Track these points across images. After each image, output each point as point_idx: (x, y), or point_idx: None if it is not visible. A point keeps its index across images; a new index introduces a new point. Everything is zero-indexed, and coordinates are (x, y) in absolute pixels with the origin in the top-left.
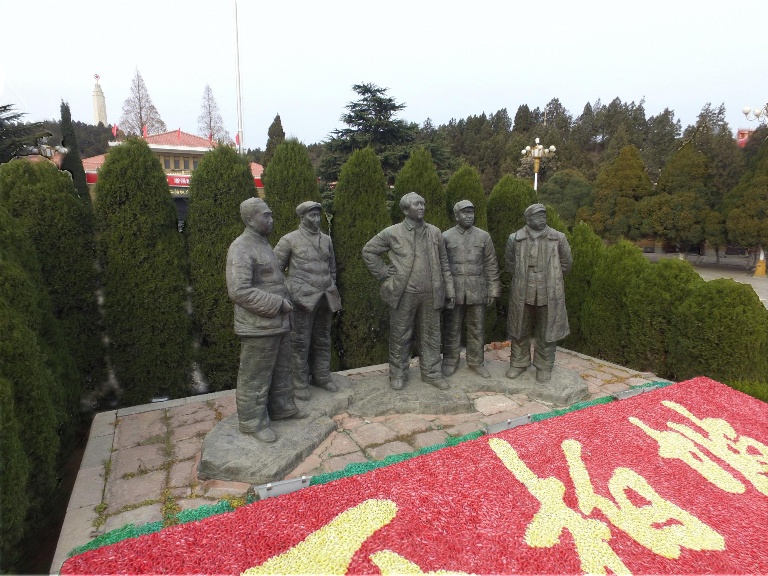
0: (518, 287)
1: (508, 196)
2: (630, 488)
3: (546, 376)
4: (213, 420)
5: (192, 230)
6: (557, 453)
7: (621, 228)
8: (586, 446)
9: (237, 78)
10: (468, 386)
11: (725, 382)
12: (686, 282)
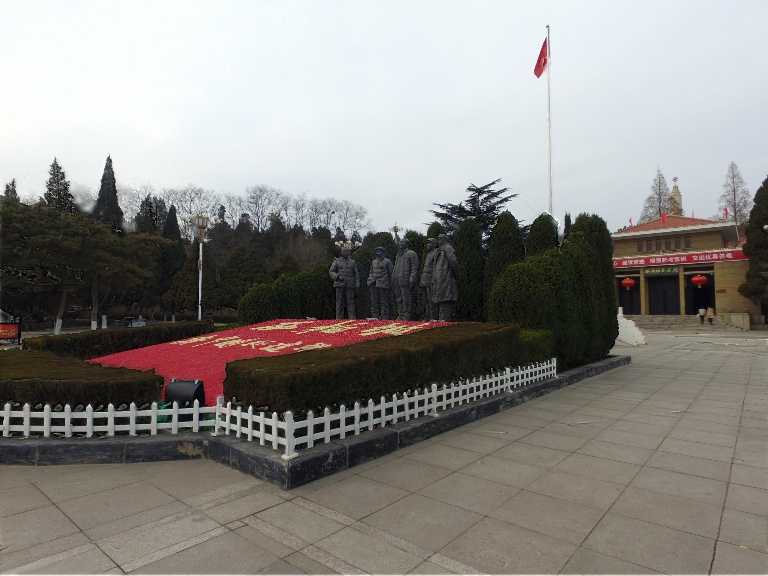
0: None
1: None
2: None
3: None
4: None
5: None
6: None
7: None
8: None
9: (549, 180)
10: None
11: None
12: None
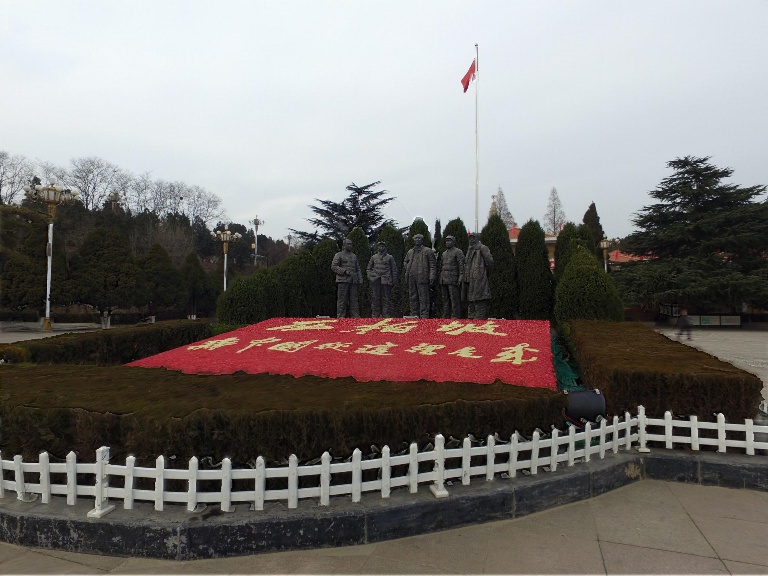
0: None
1: (562, 236)
2: None
3: None
4: None
5: None
6: None
7: None
8: None
9: (476, 188)
10: None
11: None
12: None
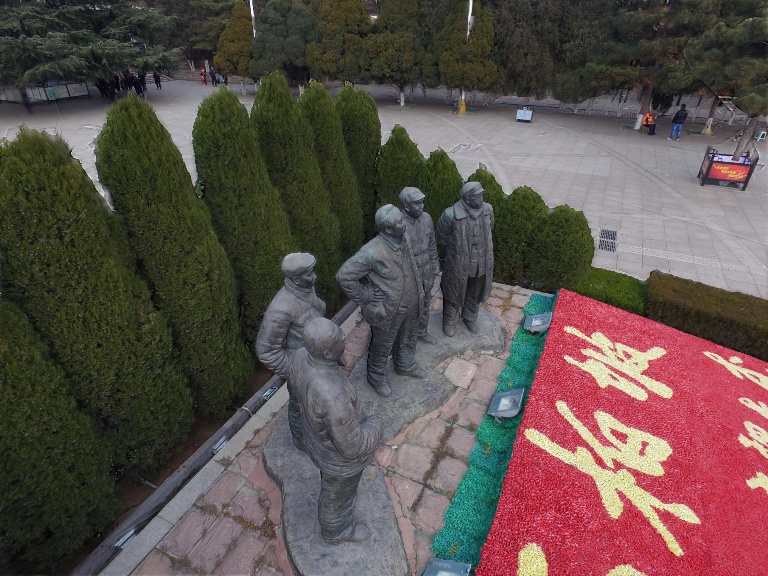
0: (462, 264)
1: (357, 114)
2: (612, 429)
3: (478, 327)
4: (250, 534)
5: (34, 293)
6: (562, 421)
7: (352, 69)
8: (568, 403)
9: None
10: (432, 362)
11: (569, 287)
12: (539, 211)
